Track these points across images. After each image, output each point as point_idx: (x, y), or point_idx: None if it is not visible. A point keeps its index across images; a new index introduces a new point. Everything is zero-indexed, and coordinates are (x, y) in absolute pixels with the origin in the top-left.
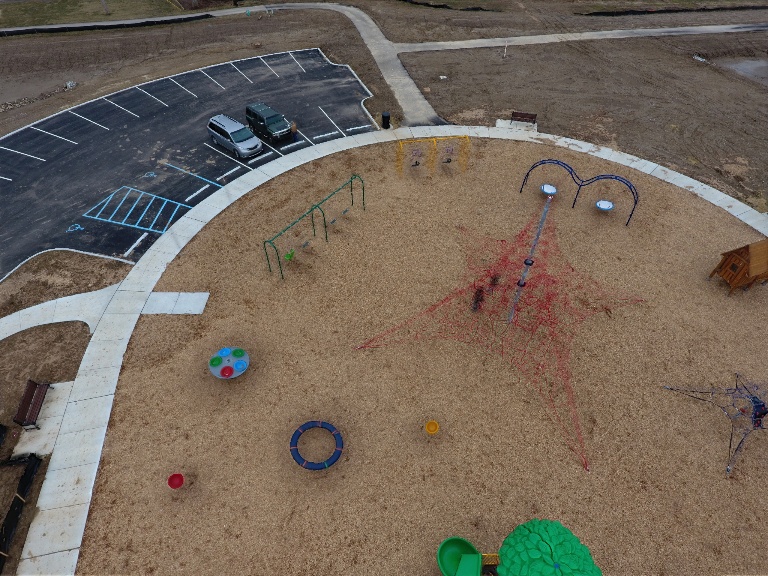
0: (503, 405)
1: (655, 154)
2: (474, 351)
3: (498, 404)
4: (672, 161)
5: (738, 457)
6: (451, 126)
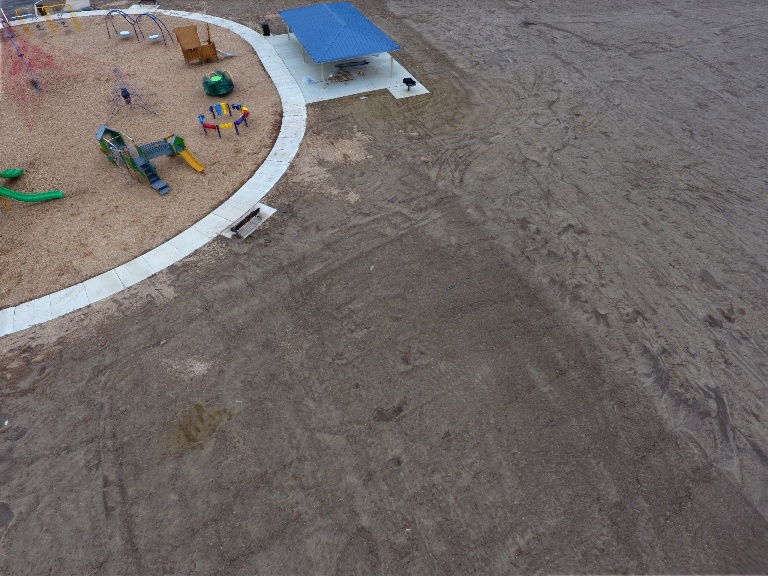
0: (5, 117)
1: (227, 13)
2: (7, 101)
3: (2, 117)
4: (234, 16)
5: (118, 119)
6: (94, 11)
